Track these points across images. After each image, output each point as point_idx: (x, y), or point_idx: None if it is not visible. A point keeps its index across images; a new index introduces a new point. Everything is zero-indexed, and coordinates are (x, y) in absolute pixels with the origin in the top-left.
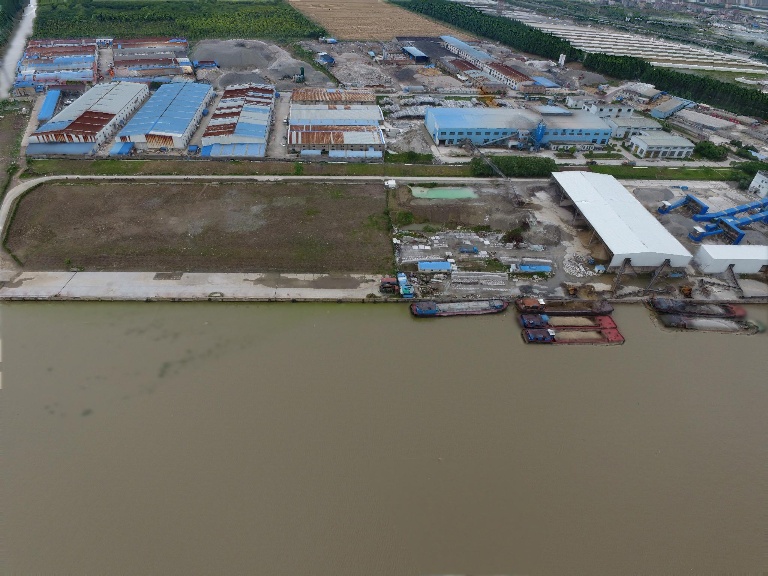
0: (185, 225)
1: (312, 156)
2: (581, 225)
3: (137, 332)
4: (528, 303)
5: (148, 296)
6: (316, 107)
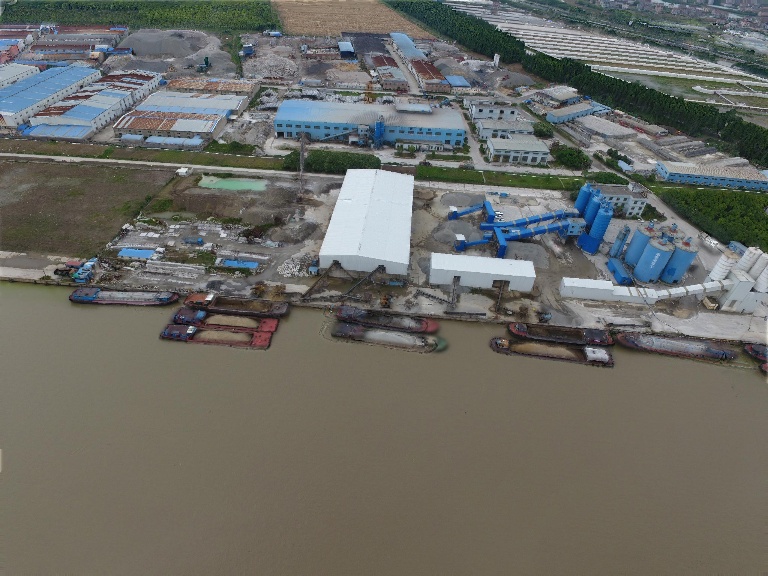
0: None
1: (131, 141)
2: None
3: None
4: (194, 298)
5: None
6: (180, 95)
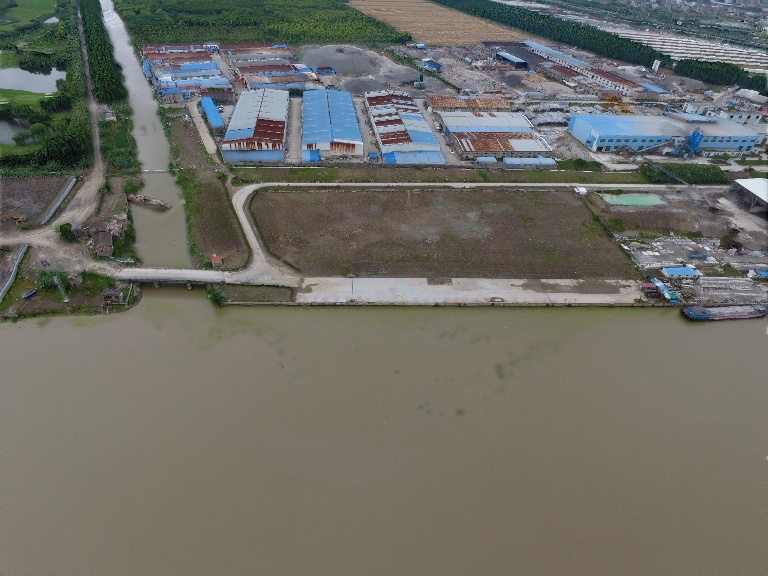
0: (419, 232)
1: (489, 163)
2: None
3: (450, 336)
4: None
5: (436, 301)
6: (463, 114)
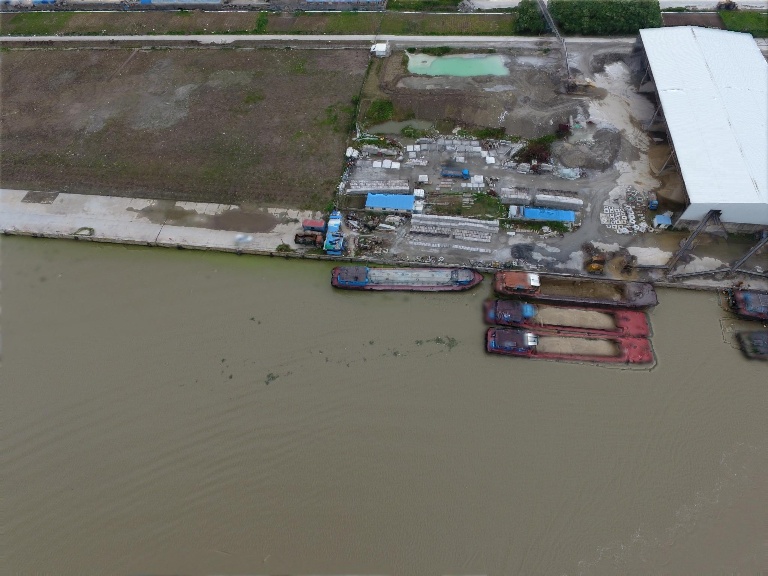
0: (86, 116)
1: (285, 1)
2: (662, 131)
3: None
4: (512, 281)
5: (6, 228)
6: None
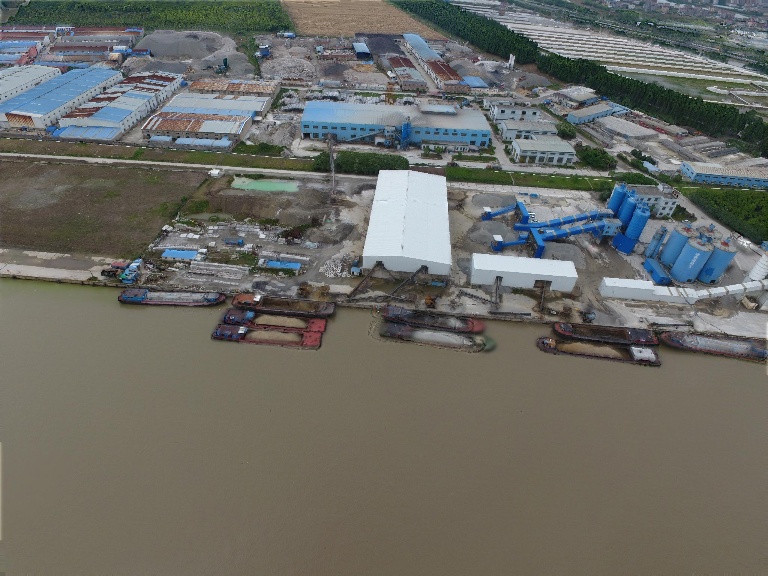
0: None
1: (160, 142)
2: None
3: None
4: (242, 298)
5: None
6: (203, 96)
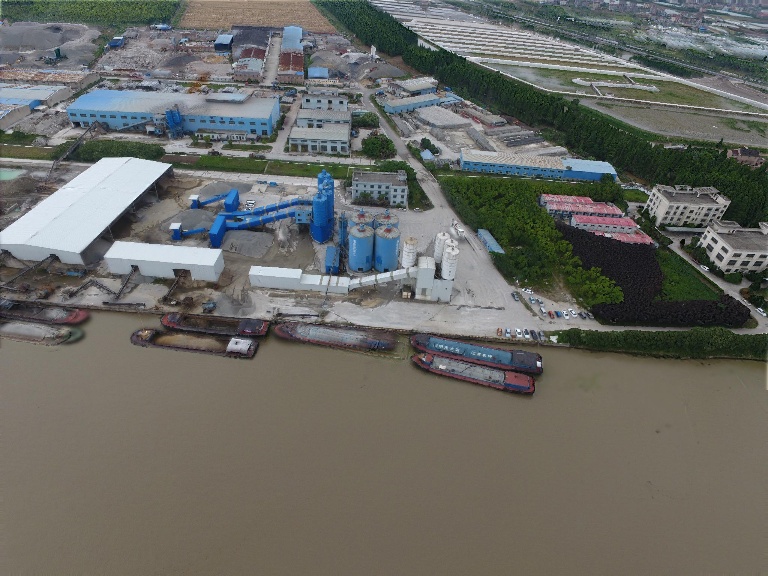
0: None
1: None
2: None
3: None
4: None
5: None
6: None
